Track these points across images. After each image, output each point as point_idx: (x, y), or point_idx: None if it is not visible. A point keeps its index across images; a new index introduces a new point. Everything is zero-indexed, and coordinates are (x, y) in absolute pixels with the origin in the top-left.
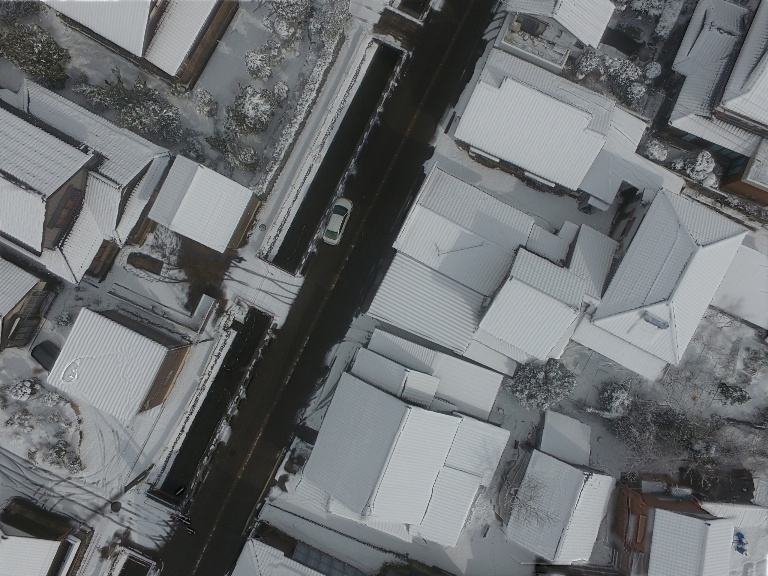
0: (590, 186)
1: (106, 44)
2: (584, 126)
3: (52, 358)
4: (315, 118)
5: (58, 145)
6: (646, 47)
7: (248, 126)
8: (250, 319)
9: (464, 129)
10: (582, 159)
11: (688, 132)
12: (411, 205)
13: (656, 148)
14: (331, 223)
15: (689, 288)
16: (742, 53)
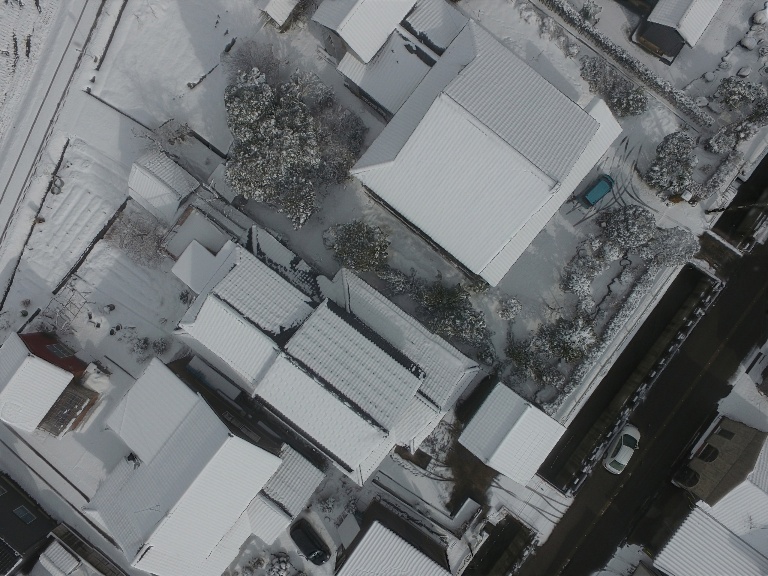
0: None
1: (408, 223)
2: None
3: (312, 544)
4: None
5: (393, 366)
6: None
7: (570, 358)
8: (503, 523)
9: None
10: None
11: None
12: (697, 441)
13: None
14: (621, 455)
15: None
16: None
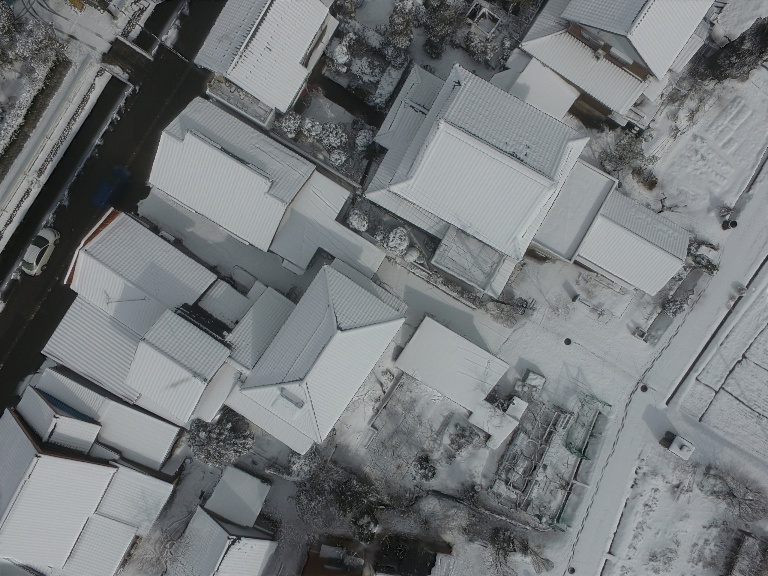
0: (282, 249)
1: None
2: (264, 190)
3: None
4: (33, 143)
5: None
6: (377, 110)
7: None
8: None
9: (156, 176)
10: (267, 222)
11: (383, 207)
12: None
13: (356, 218)
14: (27, 254)
15: (328, 370)
16: (416, 137)
